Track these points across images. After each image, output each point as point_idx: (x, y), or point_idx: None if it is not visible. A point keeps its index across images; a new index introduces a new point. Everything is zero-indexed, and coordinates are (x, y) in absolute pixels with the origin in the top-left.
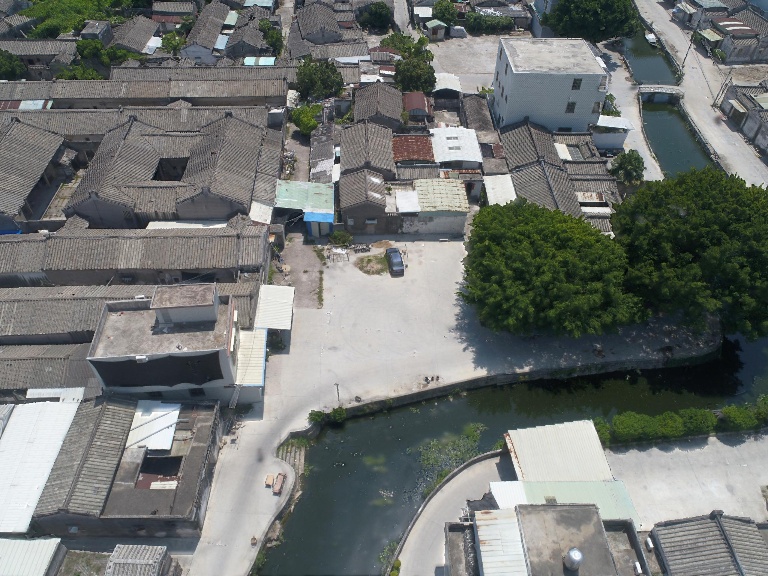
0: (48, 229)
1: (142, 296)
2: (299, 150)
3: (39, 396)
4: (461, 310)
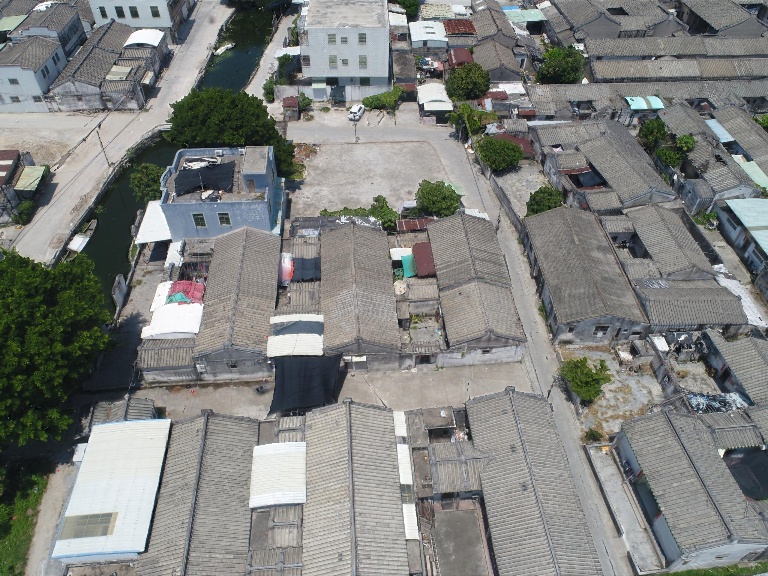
0: None
1: None
2: None
3: None
4: (424, 2)
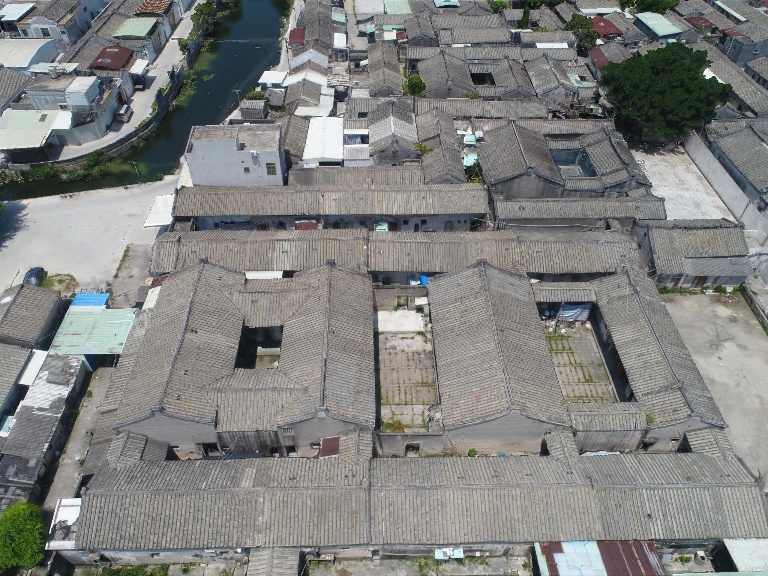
0: (396, 294)
1: (251, 151)
2: (67, 495)
3: None
4: (4, 242)
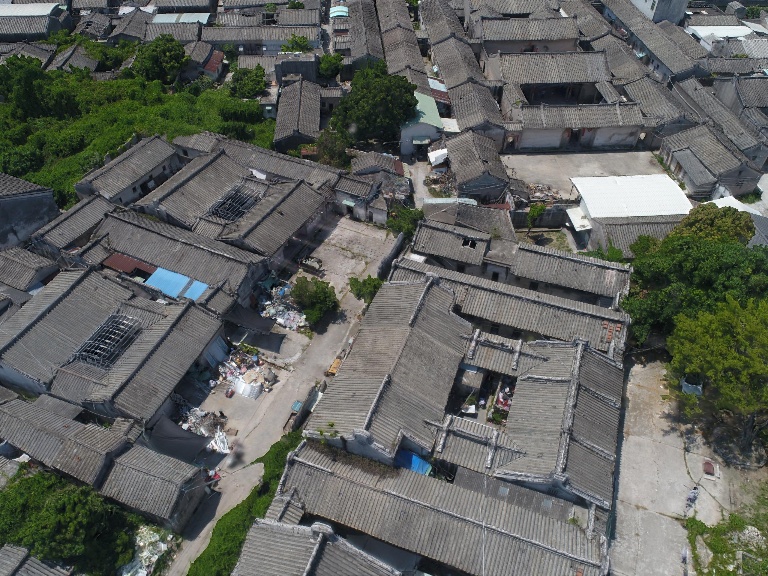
0: None
1: None
2: None
3: (692, 36)
4: None
